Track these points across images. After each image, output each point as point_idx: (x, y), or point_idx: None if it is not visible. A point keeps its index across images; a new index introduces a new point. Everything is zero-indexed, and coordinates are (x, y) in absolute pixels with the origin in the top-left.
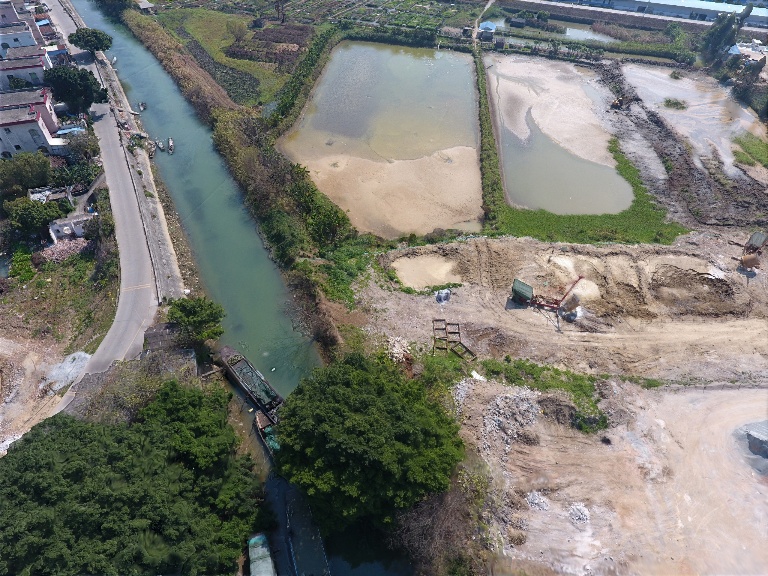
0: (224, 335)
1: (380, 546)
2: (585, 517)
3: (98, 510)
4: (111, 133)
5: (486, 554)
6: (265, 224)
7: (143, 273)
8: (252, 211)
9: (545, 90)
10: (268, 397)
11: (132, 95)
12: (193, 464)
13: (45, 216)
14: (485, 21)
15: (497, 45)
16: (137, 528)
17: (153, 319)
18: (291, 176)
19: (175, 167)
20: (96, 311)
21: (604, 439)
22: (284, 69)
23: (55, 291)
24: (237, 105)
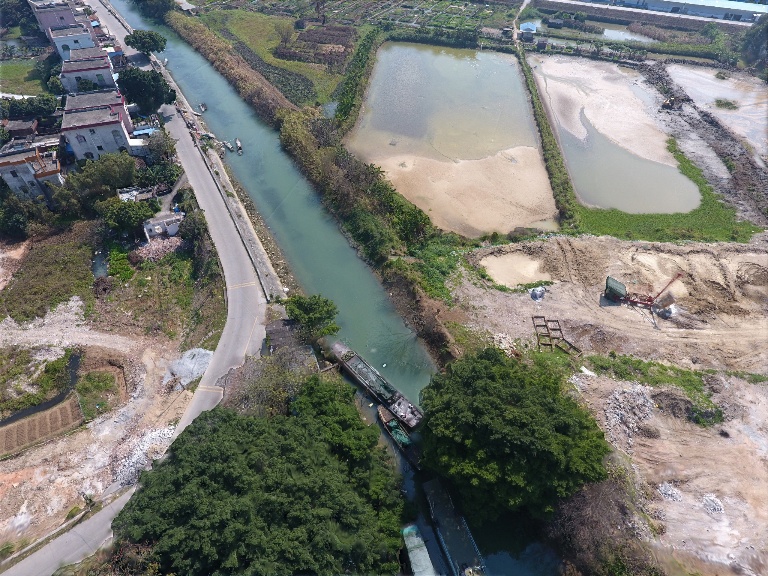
0: None
1: (539, 535)
2: (720, 508)
3: (287, 499)
4: (183, 134)
5: (635, 543)
6: (349, 223)
7: (245, 271)
8: (332, 210)
9: (594, 90)
10: (388, 392)
11: (190, 96)
12: (347, 456)
13: (141, 215)
14: (522, 22)
15: (539, 46)
16: (323, 516)
17: (265, 316)
18: (365, 176)
19: (247, 167)
20: (203, 309)
21: (722, 432)
22: (335, 70)
23: (157, 289)
24: (296, 106)
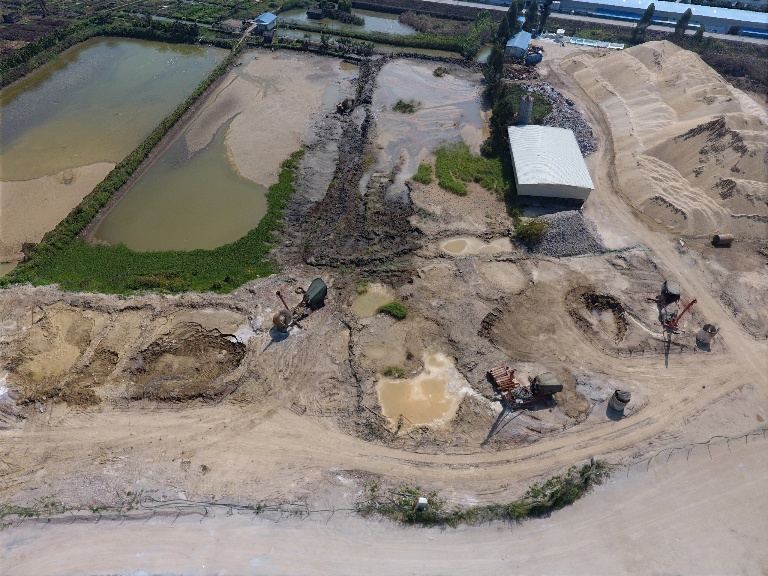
0: None
1: None
2: None
3: None
4: None
5: None
6: None
7: None
8: None
9: (278, 91)
10: None
11: None
12: None
13: None
14: (285, 12)
15: (265, 39)
16: None
17: None
18: None
19: None
20: None
21: None
22: None
23: None
24: None
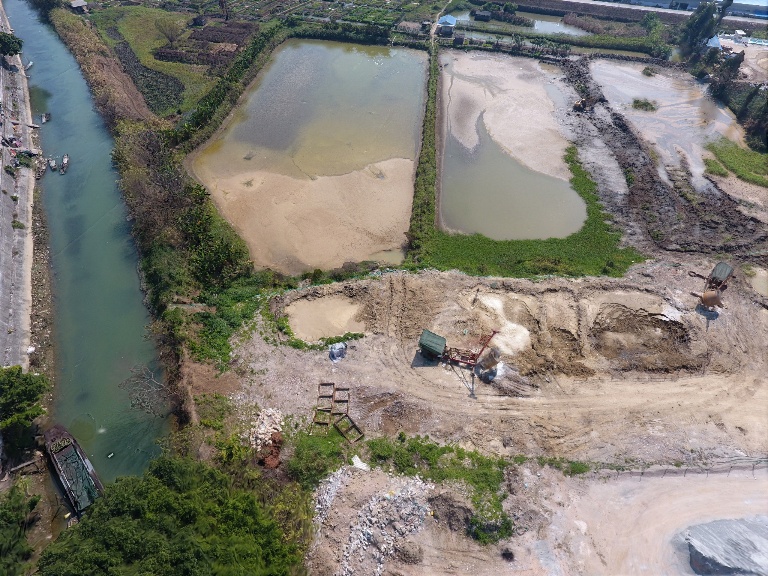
0: (63, 407)
1: None
2: None
3: None
4: None
5: None
6: (146, 260)
7: None
8: (137, 243)
9: (503, 91)
10: (88, 499)
11: (38, 105)
12: None
13: None
14: None
15: (456, 41)
16: None
17: None
18: None
19: (63, 190)
20: None
21: (506, 553)
22: (215, 72)
23: None
24: (152, 114)
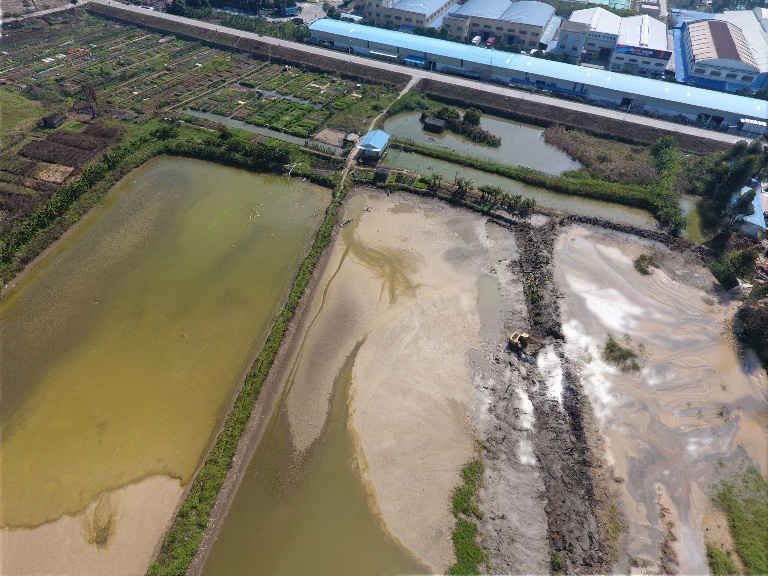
0: None
1: None
2: None
3: None
4: None
5: None
6: None
7: None
8: None
9: (410, 289)
10: None
11: None
12: None
13: None
14: (392, 117)
15: (377, 175)
16: None
17: None
18: None
19: None
20: None
21: None
22: (1, 230)
23: None
24: None
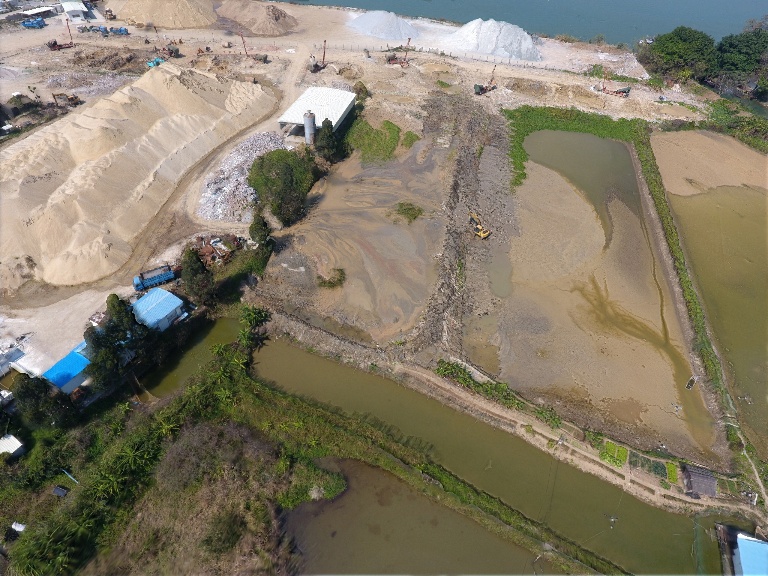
0: (759, 107)
1: None
2: None
3: None
4: None
5: None
6: None
7: None
8: None
9: (579, 288)
10: None
11: None
12: None
13: None
14: None
15: None
16: None
17: None
18: None
19: None
20: None
21: None
22: None
23: None
24: None
